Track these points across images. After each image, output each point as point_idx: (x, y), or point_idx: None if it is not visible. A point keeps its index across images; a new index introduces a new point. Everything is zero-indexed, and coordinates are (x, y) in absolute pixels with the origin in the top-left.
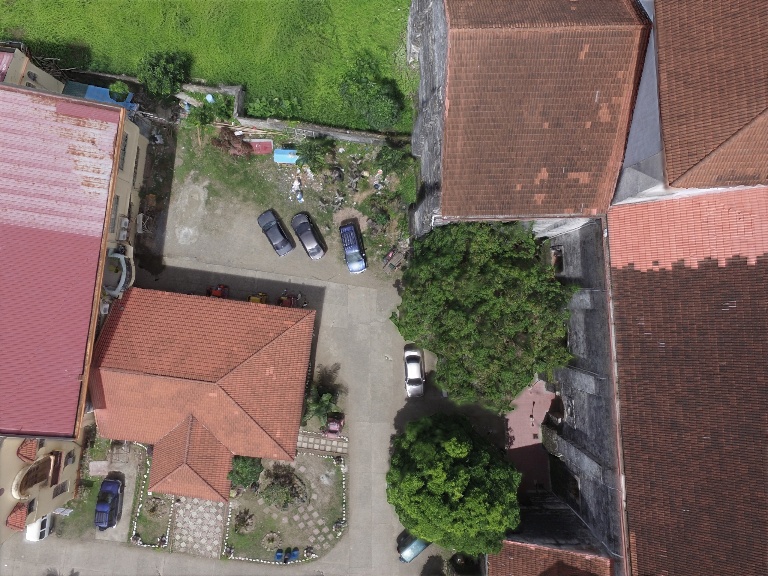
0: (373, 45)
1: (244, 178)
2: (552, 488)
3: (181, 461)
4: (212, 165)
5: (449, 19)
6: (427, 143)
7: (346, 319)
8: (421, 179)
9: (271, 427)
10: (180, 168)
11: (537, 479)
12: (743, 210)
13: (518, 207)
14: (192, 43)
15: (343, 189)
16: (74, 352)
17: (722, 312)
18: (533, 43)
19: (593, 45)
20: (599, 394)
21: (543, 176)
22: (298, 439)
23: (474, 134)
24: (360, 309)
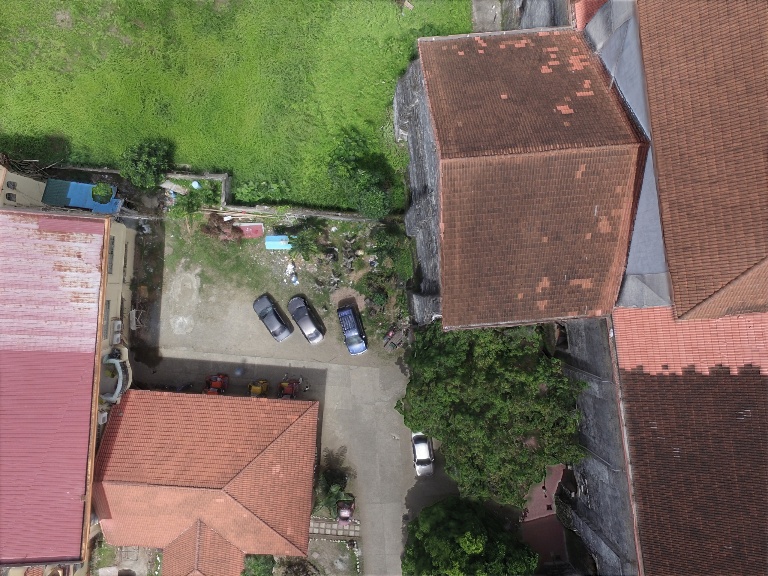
0: (359, 120)
1: (236, 263)
2: (569, 559)
3: (192, 567)
4: (203, 252)
5: (439, 147)
6: (422, 233)
7: (350, 400)
8: (417, 259)
9: (281, 525)
10: (170, 257)
11: (553, 551)
12: (753, 318)
13: (520, 313)
14: (174, 129)
15: (338, 269)
16: (75, 473)
17: (737, 421)
18: (528, 167)
19: (590, 164)
20: (613, 486)
21: (544, 284)
22: None
23: (471, 252)
24: (363, 389)
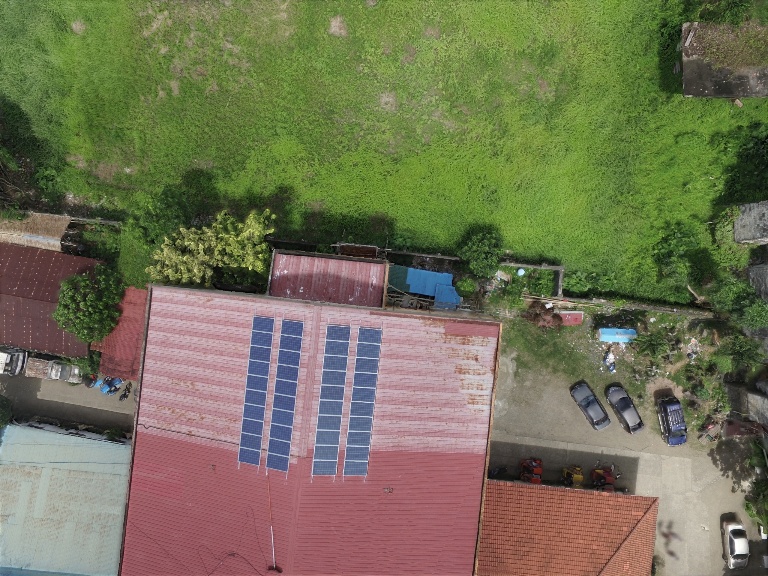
0: (685, 214)
1: (554, 350)
2: None
3: None
4: (520, 337)
5: None
6: None
7: (661, 490)
8: None
9: None
10: None
11: None
12: None
13: None
14: (500, 216)
15: (656, 360)
16: (464, 572)
17: None
18: None
19: None
20: None
21: None
22: None
23: None
24: (675, 479)
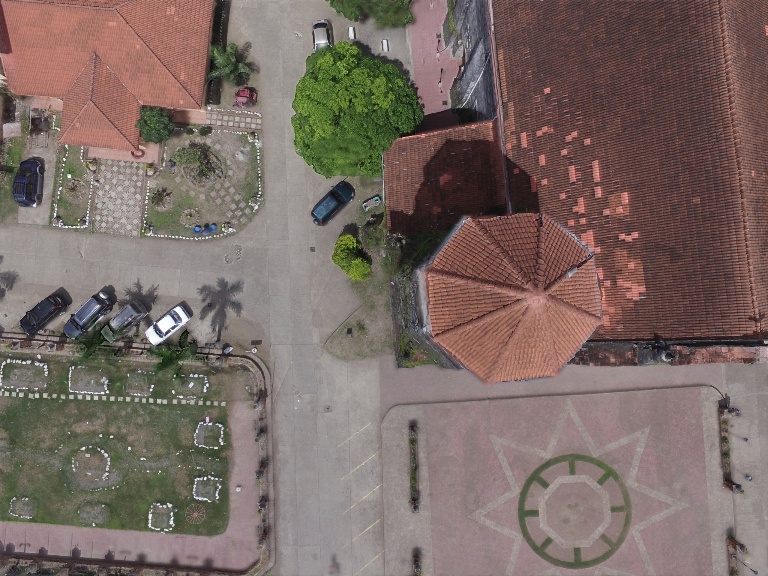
0: None
1: None
2: None
3: (86, 100)
4: None
5: None
6: None
7: None
8: None
9: (174, 67)
10: None
11: None
12: None
13: None
14: None
15: None
16: None
17: None
18: None
19: None
20: None
21: None
22: (212, 117)
23: None
24: None
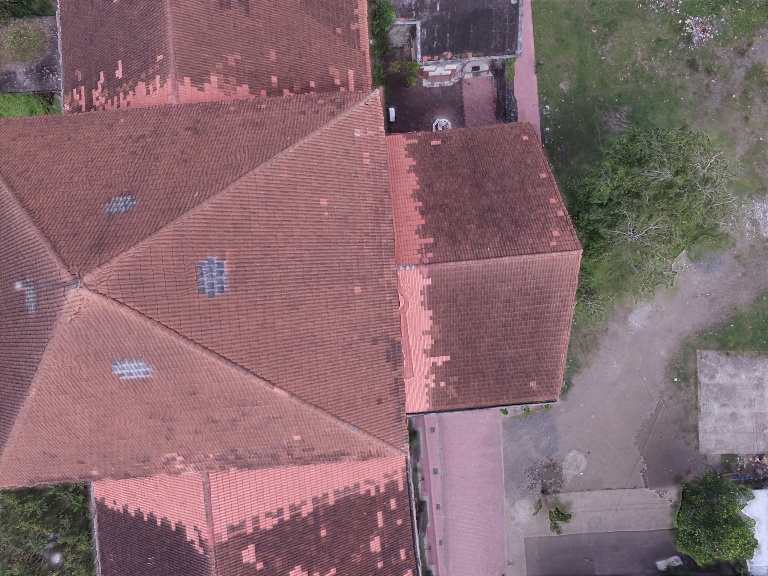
0: None
1: None
2: None
3: None
4: None
5: None
6: None
7: None
8: None
9: None
10: None
11: None
12: None
13: None
14: None
15: None
16: None
17: (148, 566)
18: None
19: None
20: None
21: None
22: None
23: None
24: None
